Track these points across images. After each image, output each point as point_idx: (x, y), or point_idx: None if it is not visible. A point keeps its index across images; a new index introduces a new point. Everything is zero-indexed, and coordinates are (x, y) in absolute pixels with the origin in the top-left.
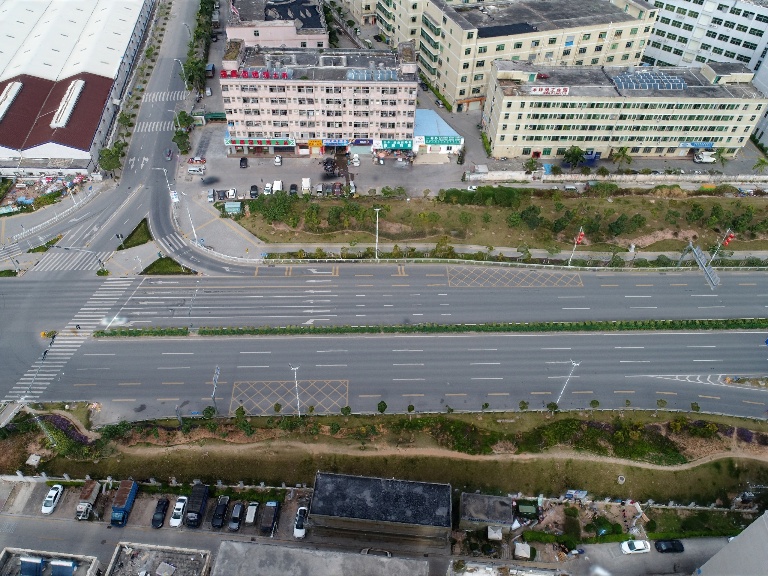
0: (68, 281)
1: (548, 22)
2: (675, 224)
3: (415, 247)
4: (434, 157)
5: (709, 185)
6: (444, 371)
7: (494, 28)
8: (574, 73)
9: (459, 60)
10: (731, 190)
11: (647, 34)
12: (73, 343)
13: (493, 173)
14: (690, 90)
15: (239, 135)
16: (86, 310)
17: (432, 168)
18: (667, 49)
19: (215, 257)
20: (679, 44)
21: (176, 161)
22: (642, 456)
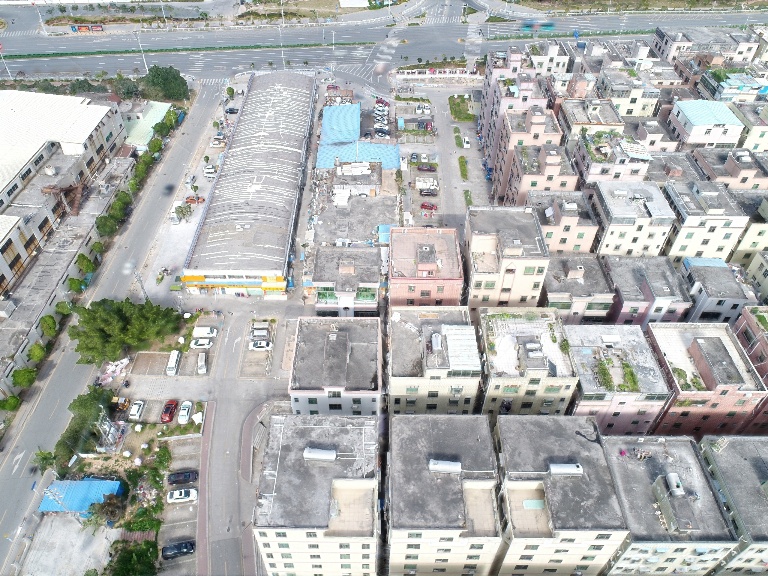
0: (449, 26)
1: None
2: None
3: None
4: None
5: None
6: None
7: None
8: None
9: None
10: None
11: None
12: (477, 43)
13: None
14: None
15: None
16: (470, 34)
17: None
18: None
19: (519, 16)
20: None
21: None
22: None
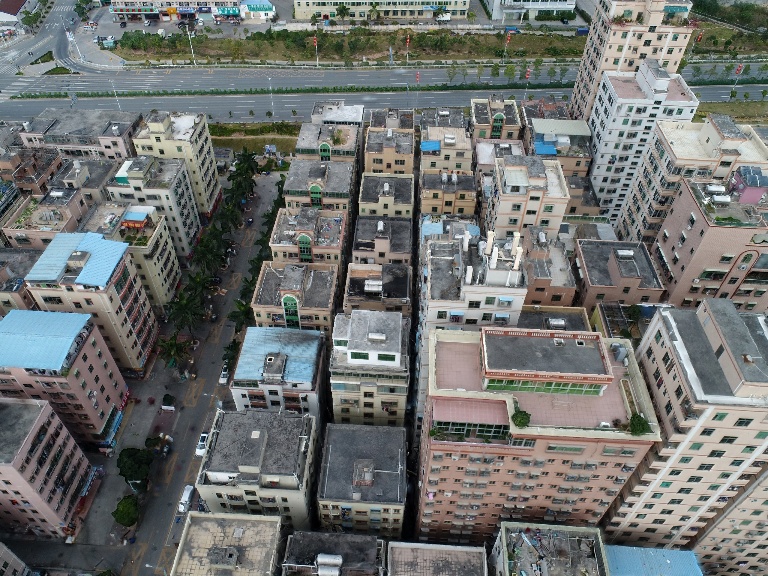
0: None
1: None
2: (398, 47)
3: None
4: (256, 20)
5: (434, 29)
6: (219, 109)
7: None
8: None
9: None
10: (447, 31)
11: None
12: None
13: (289, 25)
14: None
15: (119, 5)
16: (7, 89)
17: (252, 26)
18: None
19: (93, 67)
20: None
21: (77, 25)
22: None
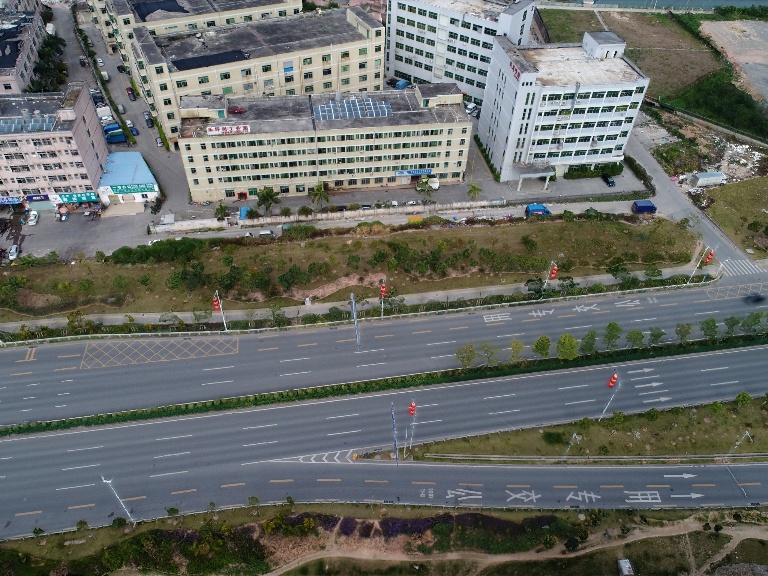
0: None
1: (266, 47)
2: (364, 267)
3: (56, 323)
4: (128, 207)
5: (416, 218)
6: (26, 483)
7: (200, 58)
8: (276, 104)
9: (157, 97)
10: (438, 222)
11: (380, 53)
12: None
13: (180, 223)
14: (395, 116)
15: None
16: None
17: (121, 221)
18: (418, 65)
19: None
20: (427, 60)
21: None
22: (218, 570)
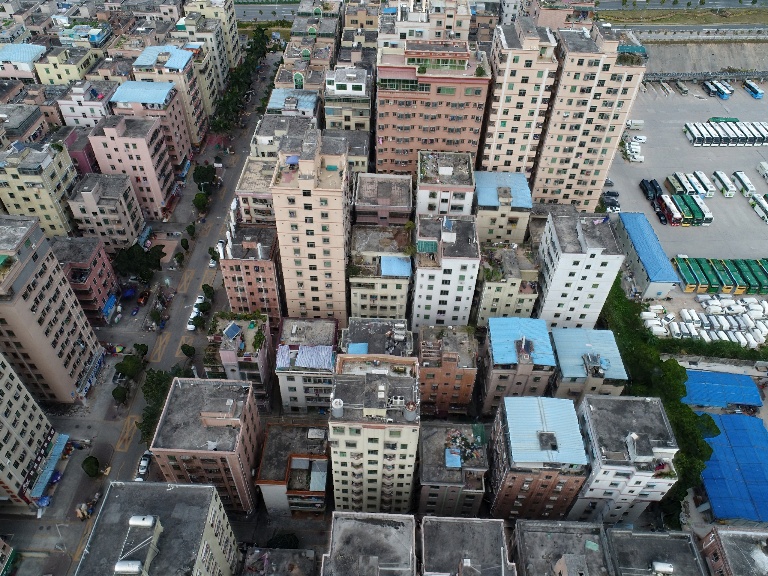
0: None
1: None
2: None
3: None
4: None
5: None
6: None
7: None
8: None
9: None
10: None
11: None
12: None
13: None
14: None
15: None
16: (68, 1)
17: None
18: None
19: None
20: None
21: None
22: None
